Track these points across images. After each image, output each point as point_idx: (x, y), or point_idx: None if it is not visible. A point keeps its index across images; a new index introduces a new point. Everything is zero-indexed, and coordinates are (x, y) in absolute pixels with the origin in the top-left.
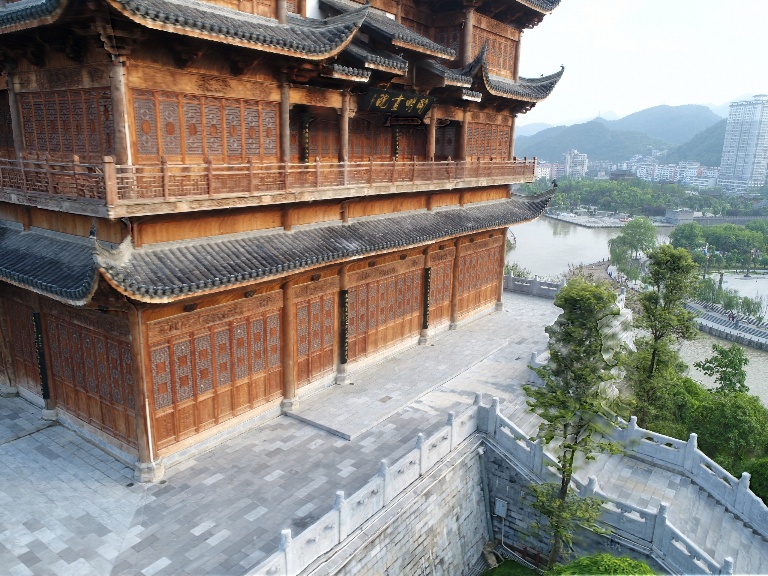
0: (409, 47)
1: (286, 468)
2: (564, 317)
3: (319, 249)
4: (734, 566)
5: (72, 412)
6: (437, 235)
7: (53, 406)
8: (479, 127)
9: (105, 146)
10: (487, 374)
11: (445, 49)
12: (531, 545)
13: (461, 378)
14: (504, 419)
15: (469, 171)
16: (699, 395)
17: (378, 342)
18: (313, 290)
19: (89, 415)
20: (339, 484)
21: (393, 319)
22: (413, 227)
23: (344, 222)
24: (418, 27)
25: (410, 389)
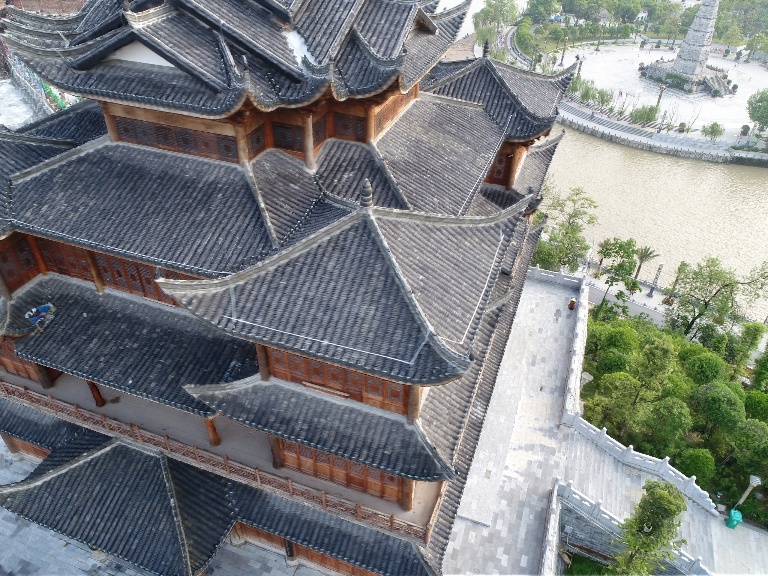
0: None
1: (471, 568)
2: (653, 505)
3: (469, 433)
4: (690, 537)
5: (317, 563)
6: None
7: (295, 558)
8: None
9: (387, 480)
10: (531, 417)
11: None
12: (586, 545)
13: (518, 428)
14: (576, 492)
15: None
16: (631, 345)
17: None
18: None
19: (338, 569)
20: (507, 574)
21: None
22: None
23: None
24: None
25: (497, 457)
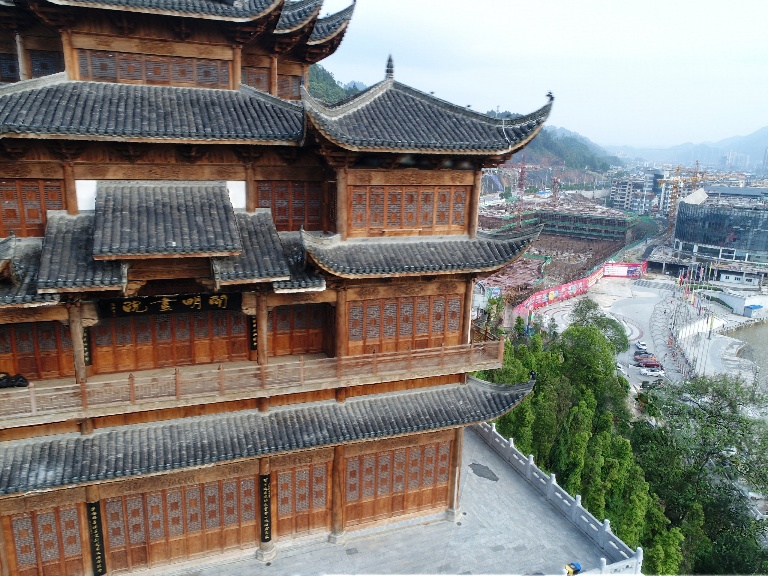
0: (132, 257)
1: None
2: None
3: None
4: None
5: None
6: (214, 459)
7: None
8: (381, 303)
9: None
10: None
11: (213, 247)
12: None
13: None
14: None
15: (315, 371)
16: None
17: (172, 552)
18: (38, 502)
19: None
20: None
21: (200, 529)
22: (195, 441)
23: (83, 434)
24: (298, 184)
25: None
